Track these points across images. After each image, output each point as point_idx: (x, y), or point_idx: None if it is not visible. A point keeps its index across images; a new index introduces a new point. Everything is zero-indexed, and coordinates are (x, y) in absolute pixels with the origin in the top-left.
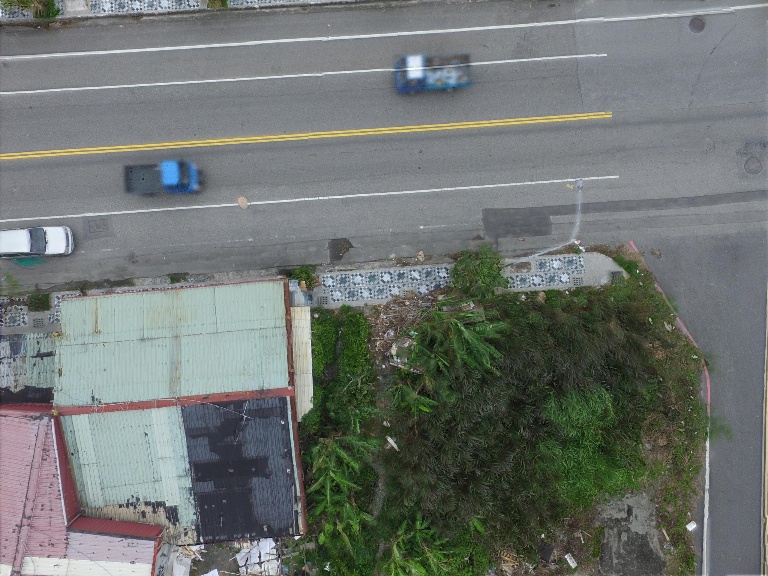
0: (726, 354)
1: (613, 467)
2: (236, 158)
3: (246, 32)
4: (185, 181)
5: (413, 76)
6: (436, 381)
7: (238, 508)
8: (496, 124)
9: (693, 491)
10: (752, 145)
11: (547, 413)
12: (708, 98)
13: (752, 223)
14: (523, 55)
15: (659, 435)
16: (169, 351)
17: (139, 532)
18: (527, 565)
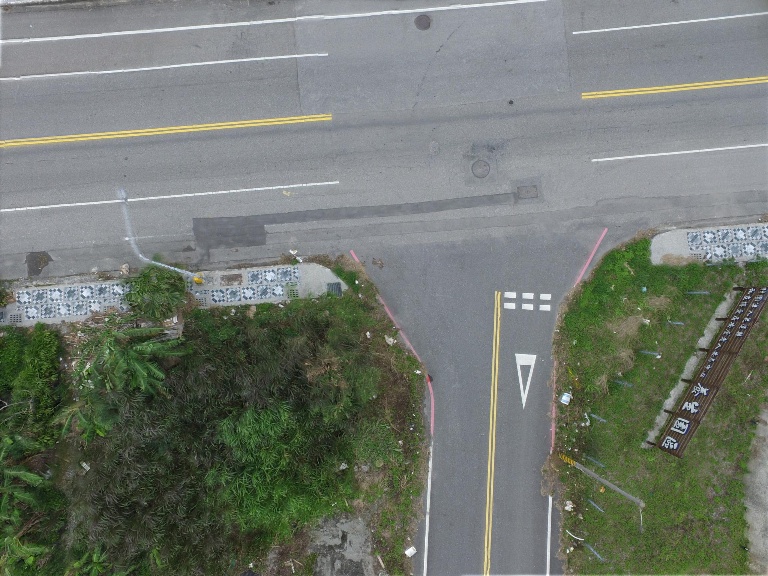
0: (451, 369)
1: (297, 493)
2: None
3: None
4: None
5: (120, 79)
6: (93, 405)
7: None
8: (207, 128)
9: (414, 515)
10: (479, 147)
11: (218, 437)
12: (434, 98)
13: (479, 230)
14: (239, 55)
15: (376, 456)
16: None
17: None
18: None
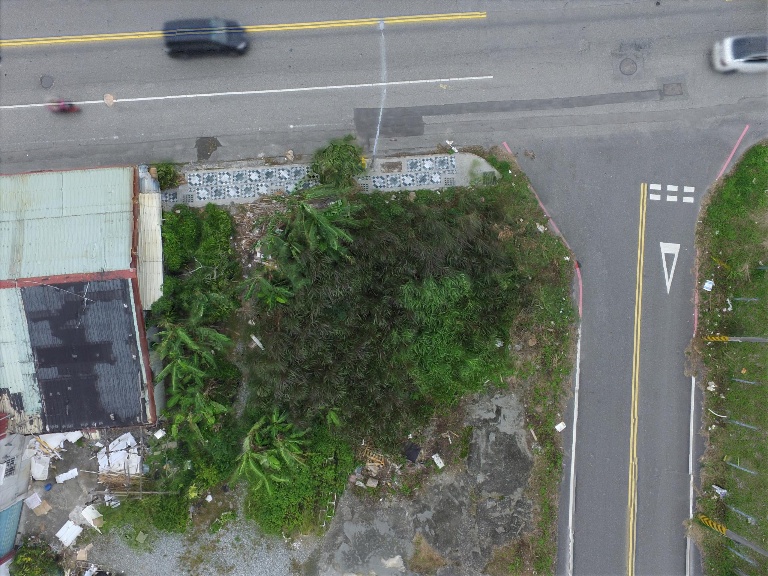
0: (598, 255)
1: (469, 358)
2: (102, 54)
3: None
4: (49, 77)
5: None
6: (285, 266)
7: (84, 396)
8: (368, 23)
9: (563, 392)
10: (627, 46)
11: (400, 301)
12: None
13: (626, 124)
14: None
15: (529, 335)
16: (12, 235)
17: None
18: (393, 465)
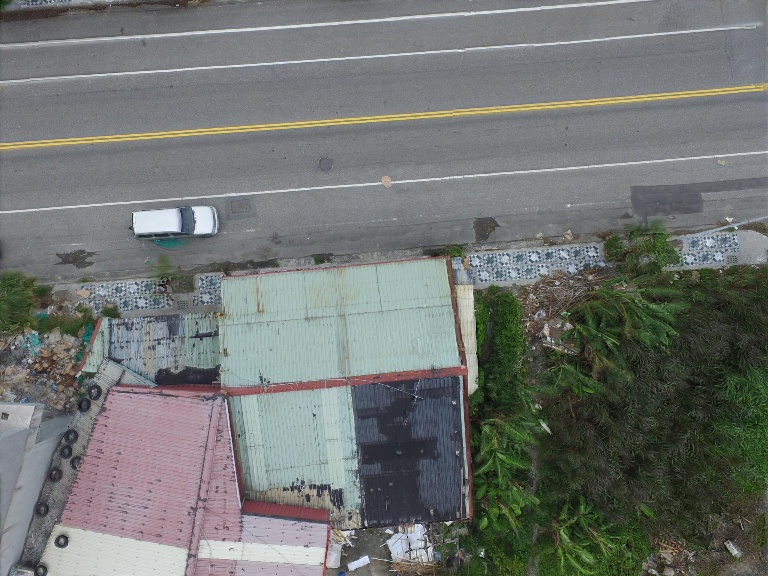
0: None
1: None
2: (379, 136)
3: (386, 8)
4: (328, 160)
5: (557, 51)
6: (609, 360)
7: (404, 491)
8: (644, 99)
9: None
10: None
11: (722, 393)
12: None
13: None
14: (669, 28)
15: None
16: (334, 330)
17: (310, 515)
18: (685, 552)
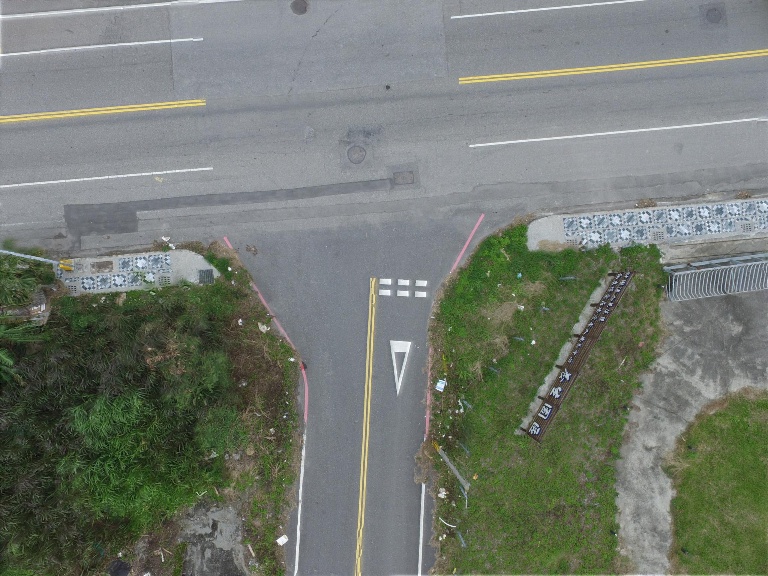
0: (325, 356)
1: (153, 481)
2: None
3: None
4: None
5: None
6: None
7: None
8: (78, 114)
9: (286, 503)
10: (355, 133)
11: (70, 424)
12: (311, 84)
13: (354, 216)
14: (113, 40)
15: (247, 444)
16: None
17: None
18: None
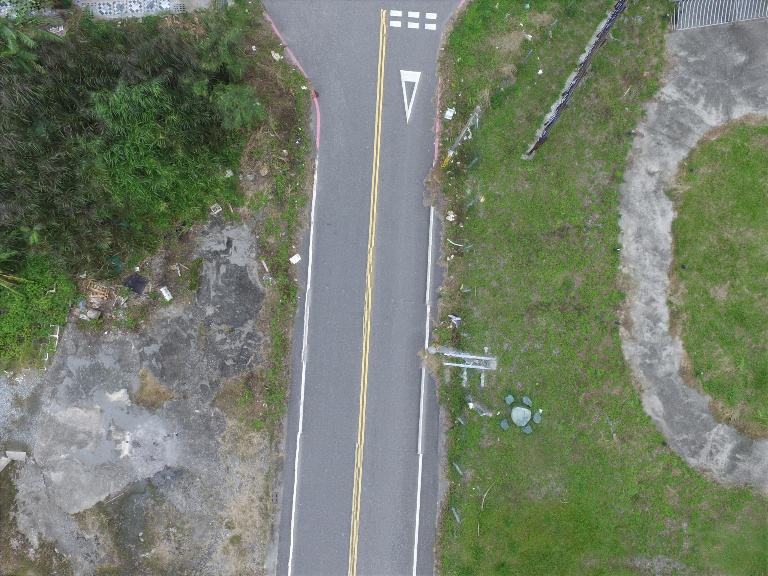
0: (336, 84)
1: None
2: None
3: None
4: None
5: None
6: None
7: None
8: None
9: (298, 224)
10: None
11: (91, 109)
12: None
13: None
14: None
15: (261, 165)
16: None
17: None
18: (119, 298)
